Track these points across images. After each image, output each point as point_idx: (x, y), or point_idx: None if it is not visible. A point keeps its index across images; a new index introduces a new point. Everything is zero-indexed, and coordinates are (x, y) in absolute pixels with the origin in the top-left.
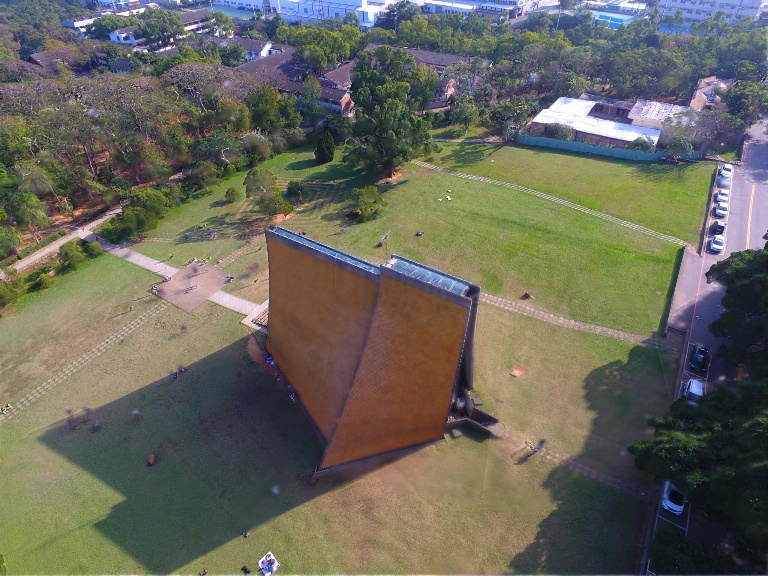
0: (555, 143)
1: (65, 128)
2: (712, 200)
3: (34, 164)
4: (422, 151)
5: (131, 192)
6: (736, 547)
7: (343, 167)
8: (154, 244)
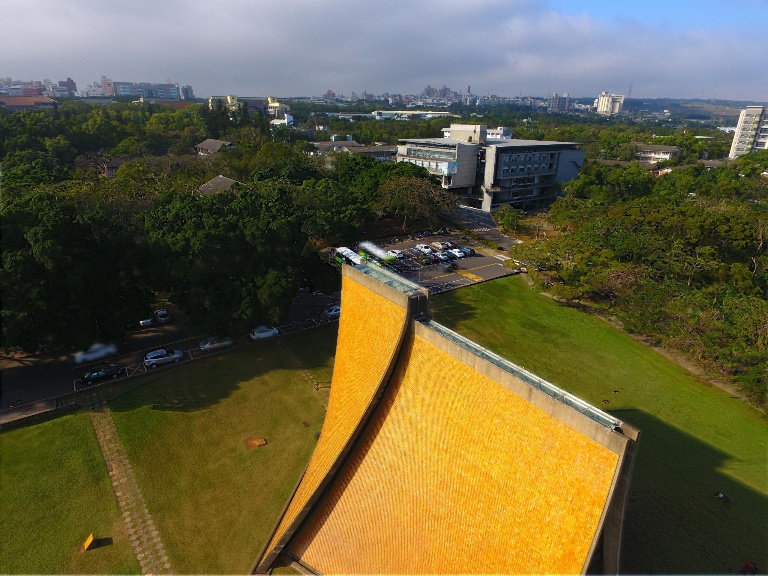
0: None
1: None
2: None
3: None
4: None
5: None
6: None
7: None
8: None
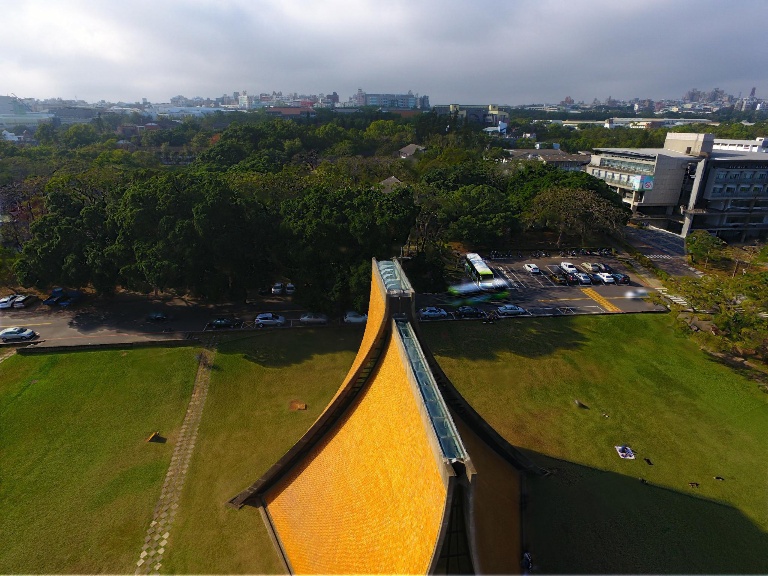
0: None
1: None
2: None
3: None
4: None
5: None
6: None
7: None
8: None
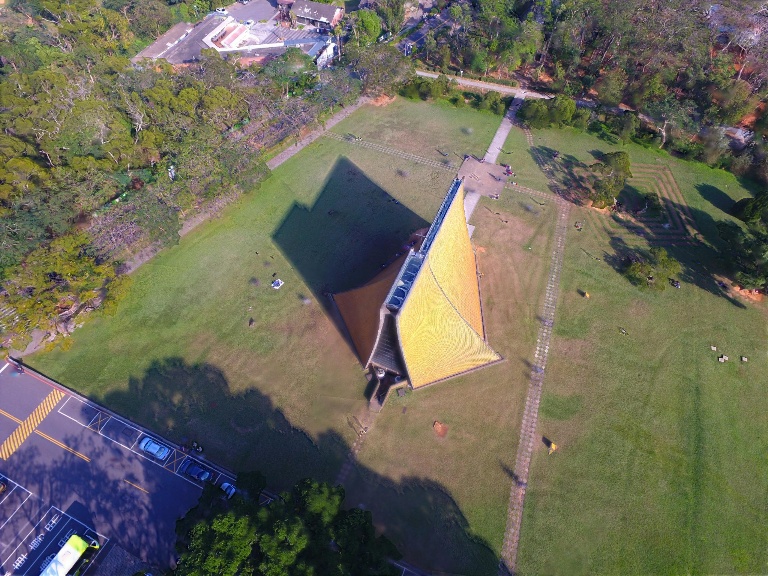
0: None
1: (617, 14)
2: None
3: (540, 28)
4: None
5: (589, 95)
6: None
7: None
8: (523, 137)
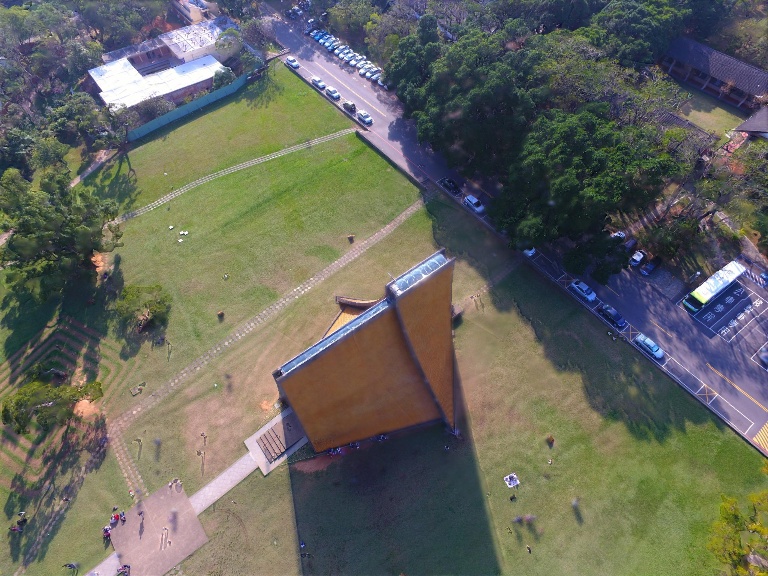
0: (165, 119)
1: None
2: (319, 90)
3: None
4: (105, 218)
5: None
6: (572, 239)
7: (22, 308)
8: None
